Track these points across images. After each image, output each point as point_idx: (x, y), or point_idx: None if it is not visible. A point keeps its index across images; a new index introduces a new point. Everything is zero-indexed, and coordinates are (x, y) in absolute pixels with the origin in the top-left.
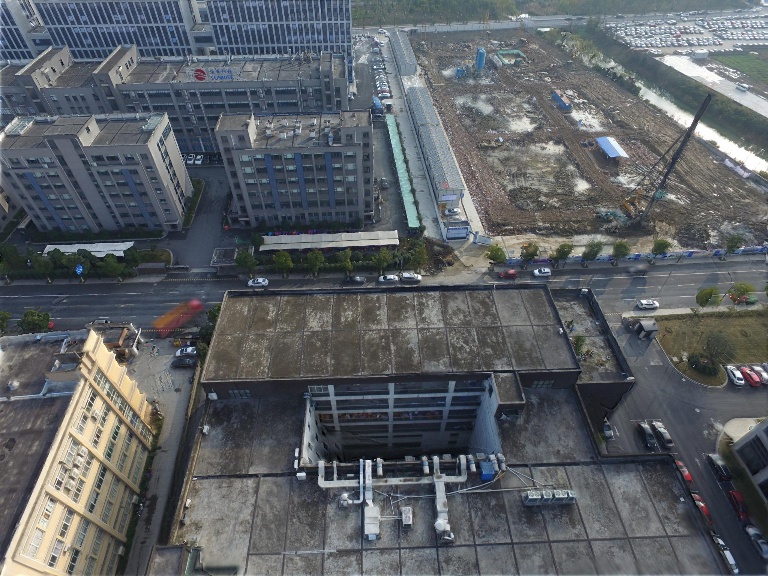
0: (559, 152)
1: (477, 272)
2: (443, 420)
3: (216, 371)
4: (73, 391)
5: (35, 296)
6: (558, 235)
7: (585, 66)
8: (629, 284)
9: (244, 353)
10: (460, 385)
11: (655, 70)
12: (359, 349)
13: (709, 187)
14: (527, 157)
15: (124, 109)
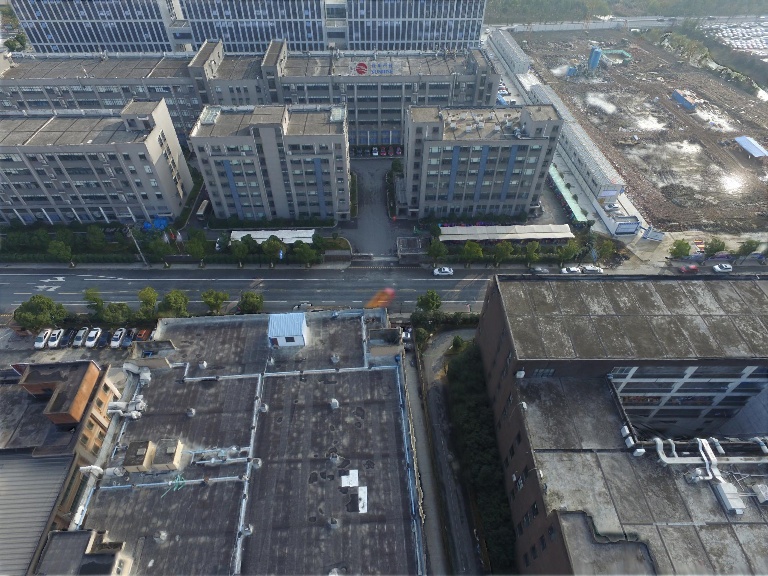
0: (697, 151)
1: (655, 267)
2: (711, 406)
3: (524, 350)
4: (394, 365)
5: (231, 280)
6: (725, 232)
7: (694, 67)
8: None
9: (542, 334)
10: (757, 371)
11: (766, 72)
12: (653, 333)
13: None
14: (667, 155)
15: (283, 101)
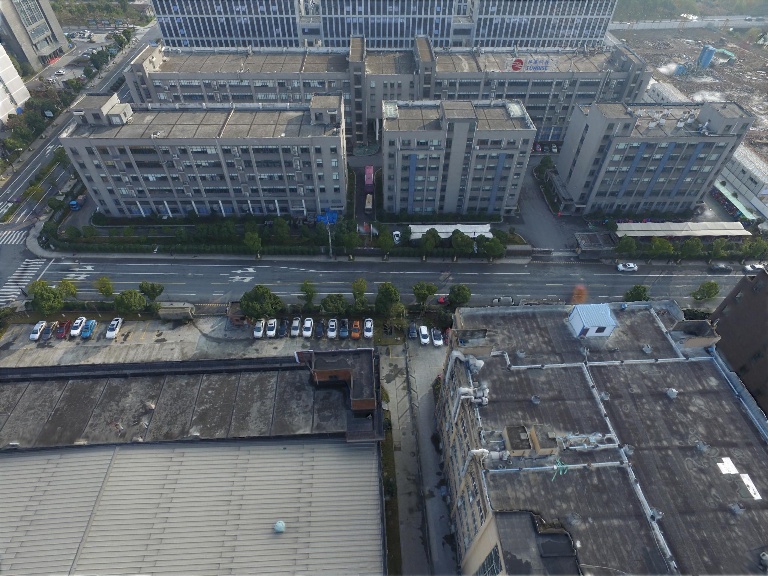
0: None
1: None
2: None
3: None
4: None
5: (419, 273)
6: None
7: None
8: None
9: None
10: None
11: None
12: None
13: None
14: None
15: (433, 97)
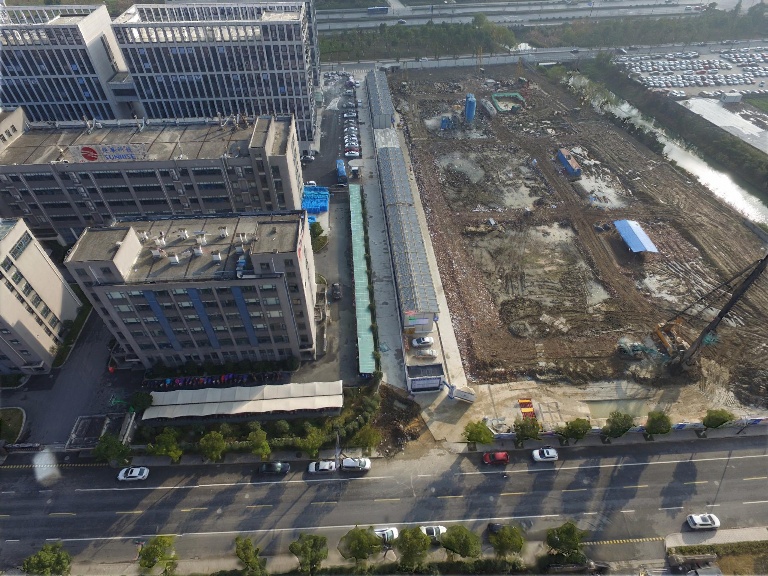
0: (566, 240)
1: (452, 452)
2: None
3: None
4: None
5: None
6: (567, 382)
7: (596, 113)
8: (672, 477)
9: None
10: None
11: (680, 118)
12: None
13: (767, 298)
14: (525, 248)
15: None
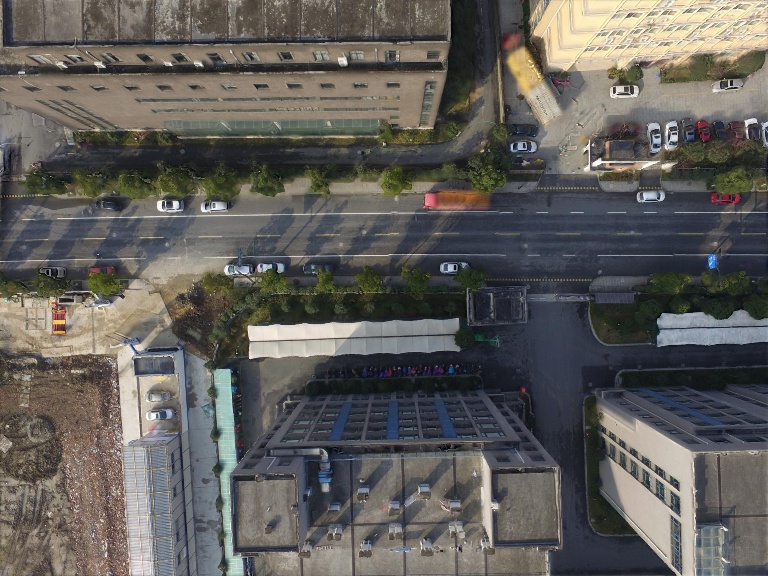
0: None
1: (145, 281)
2: None
3: None
4: None
5: (761, 255)
6: (8, 354)
7: None
8: None
9: None
10: None
11: None
12: None
13: None
14: None
15: None
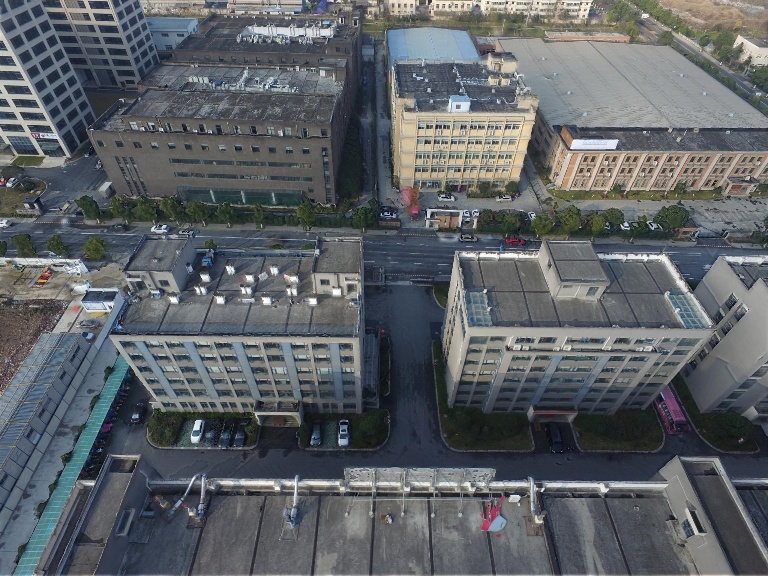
0: None
1: (121, 264)
2: None
3: None
4: None
5: None
6: None
7: None
8: None
9: None
10: None
11: None
12: None
13: None
14: None
15: None
